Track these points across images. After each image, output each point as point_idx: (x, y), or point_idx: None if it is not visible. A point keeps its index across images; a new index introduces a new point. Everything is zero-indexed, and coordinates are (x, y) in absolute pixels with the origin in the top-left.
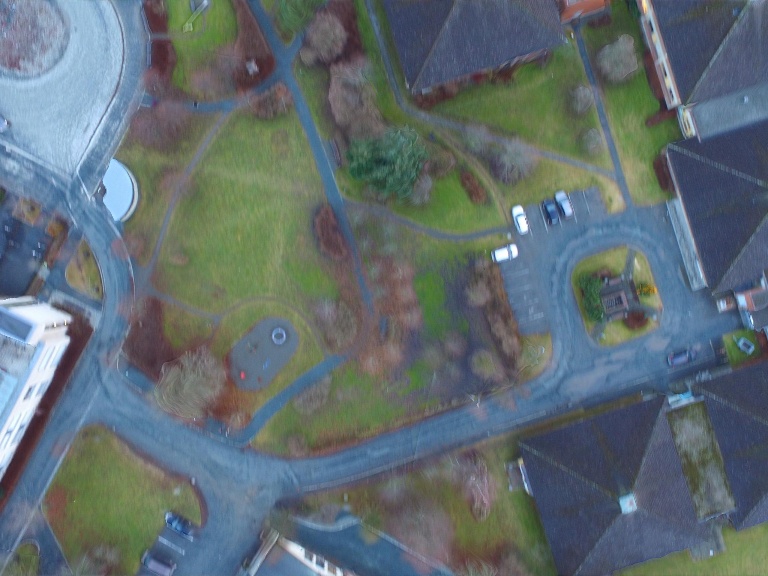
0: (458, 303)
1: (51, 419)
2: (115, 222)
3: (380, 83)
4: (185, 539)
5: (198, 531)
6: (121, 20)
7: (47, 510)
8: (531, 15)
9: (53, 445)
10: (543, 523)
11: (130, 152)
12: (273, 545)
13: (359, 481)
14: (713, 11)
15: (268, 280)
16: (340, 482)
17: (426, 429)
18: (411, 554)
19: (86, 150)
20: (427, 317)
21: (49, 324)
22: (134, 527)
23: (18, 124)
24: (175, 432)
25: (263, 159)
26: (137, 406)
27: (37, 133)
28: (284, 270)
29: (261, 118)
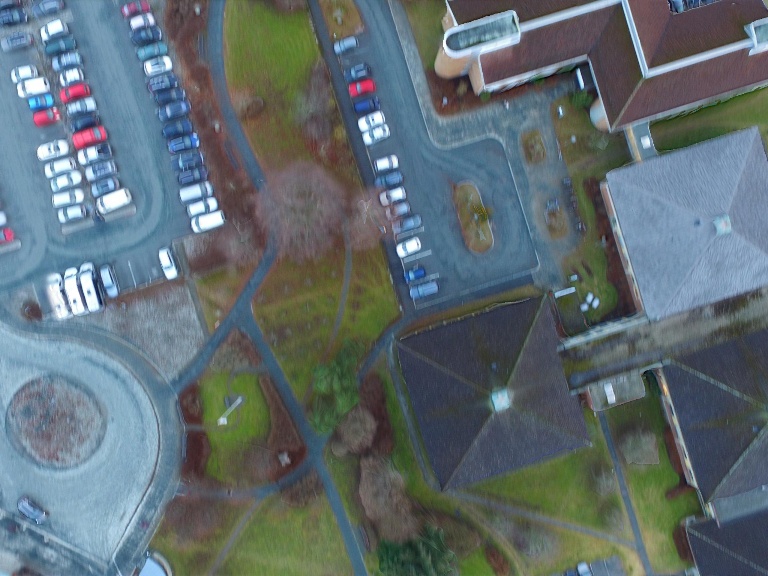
0: None
1: None
2: None
3: (408, 462)
4: None
5: None
6: (157, 411)
7: None
8: (557, 428)
9: None
10: None
11: (165, 540)
12: None
13: None
14: (733, 424)
15: None
16: None
17: None
18: None
19: (122, 538)
20: None
21: None
22: None
23: (56, 513)
24: None
25: (294, 544)
26: None
27: (74, 522)
28: None
29: (293, 506)
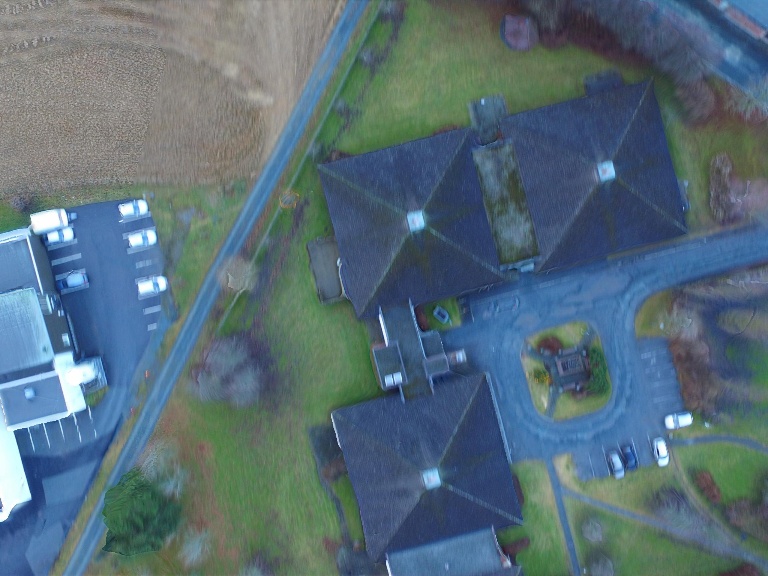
0: (739, 376)
1: None
2: None
3: None
4: None
5: None
6: None
7: None
8: None
9: None
10: None
11: None
12: None
13: None
14: None
15: None
16: None
17: None
18: None
19: None
20: None
21: None
22: None
23: None
24: None
25: None
26: None
27: None
28: None
29: None
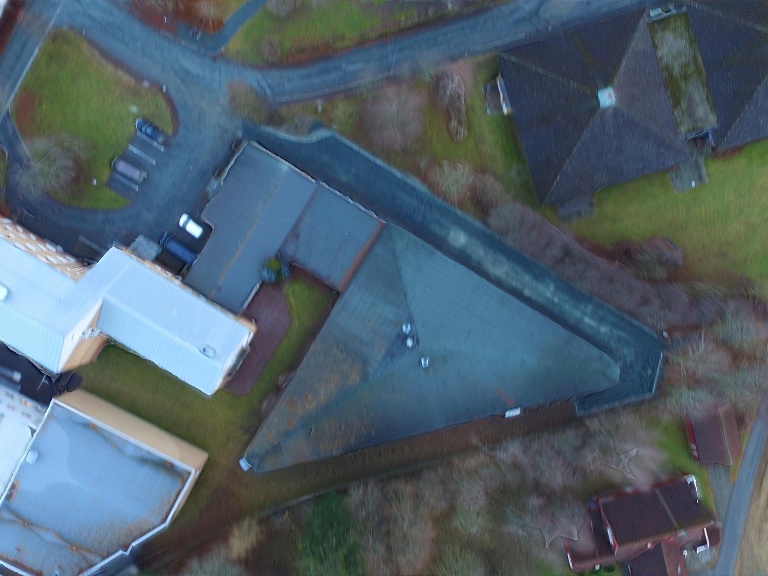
0: None
1: (20, 21)
2: None
3: None
4: (156, 148)
5: (169, 140)
6: None
7: (15, 114)
8: None
9: (22, 48)
10: (521, 137)
11: None
12: (244, 146)
13: (333, 95)
14: None
15: None
16: (314, 94)
17: (402, 46)
18: (386, 169)
19: None
20: None
21: None
22: (104, 134)
23: None
24: (146, 38)
25: None
26: (107, 10)
27: None
28: None
29: None
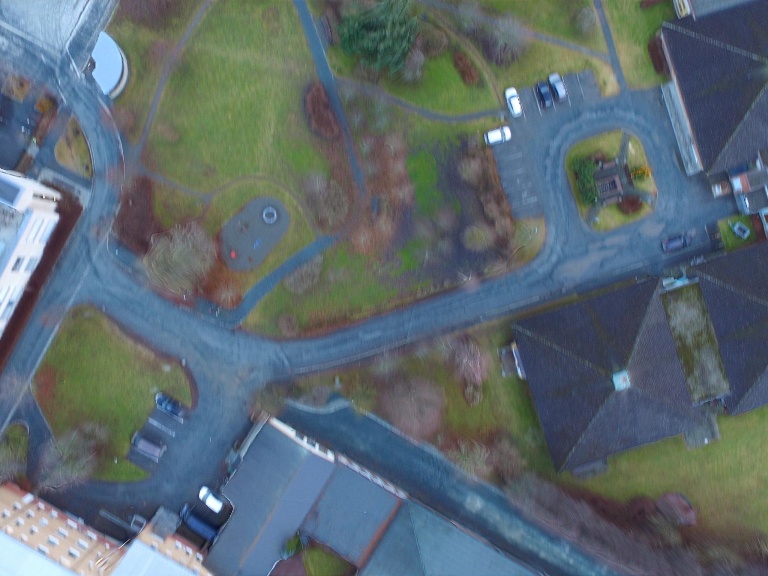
0: (450, 183)
1: (40, 299)
2: (105, 99)
3: None
4: (175, 421)
5: (188, 413)
6: None
7: (36, 390)
8: None
9: (42, 325)
10: (536, 406)
11: (120, 28)
12: (264, 424)
13: (351, 364)
14: None
15: (259, 159)
16: (331, 365)
17: (418, 313)
18: (403, 437)
19: (76, 26)
20: (419, 197)
21: (37, 193)
22: (124, 408)
23: None
24: (165, 312)
25: (254, 36)
26: (127, 286)
27: (26, 9)
28: (275, 149)
29: None
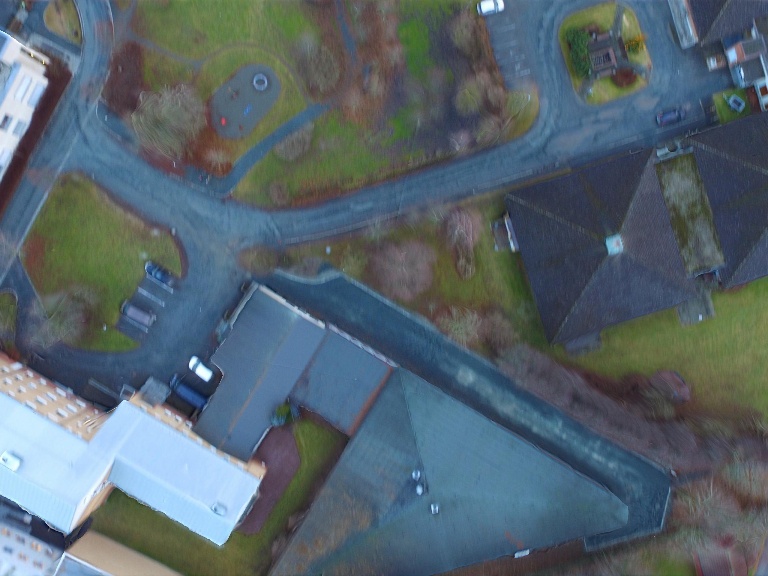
0: (443, 51)
1: (29, 166)
2: None
3: None
4: (165, 290)
5: (178, 282)
6: None
7: (25, 258)
8: None
9: (31, 193)
10: (529, 277)
11: None
12: (254, 291)
13: (342, 235)
14: None
15: (249, 26)
16: (322, 235)
17: (410, 185)
18: (394, 309)
19: None
20: (411, 64)
21: (25, 49)
22: (113, 277)
23: None
24: (155, 181)
25: None
26: (116, 154)
27: None
28: (266, 16)
29: None
